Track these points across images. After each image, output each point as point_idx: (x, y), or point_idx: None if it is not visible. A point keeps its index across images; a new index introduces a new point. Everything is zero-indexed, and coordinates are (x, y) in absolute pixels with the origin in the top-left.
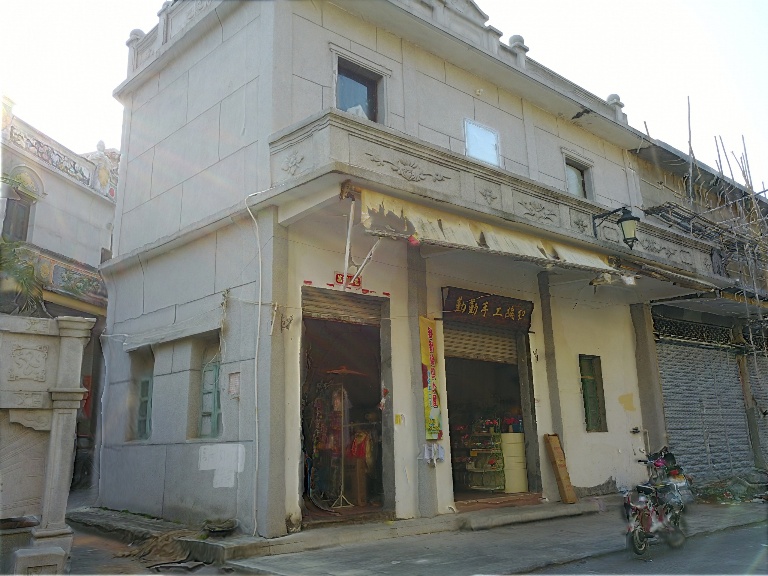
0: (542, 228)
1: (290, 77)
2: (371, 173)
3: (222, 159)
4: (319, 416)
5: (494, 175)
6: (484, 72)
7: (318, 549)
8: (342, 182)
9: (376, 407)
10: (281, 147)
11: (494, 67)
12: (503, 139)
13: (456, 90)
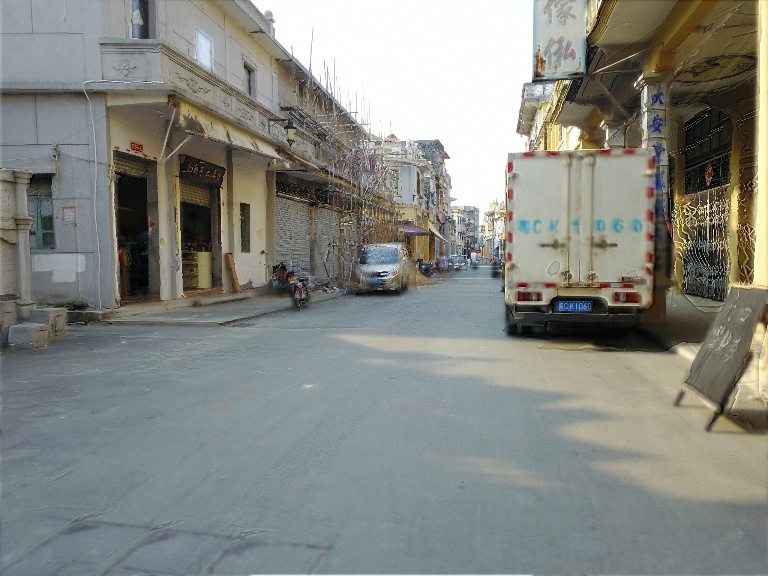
0: (253, 130)
1: None
2: (188, 93)
3: (36, 33)
4: None
5: (230, 89)
6: None
7: (137, 315)
8: (169, 94)
9: (142, 233)
10: (112, 50)
11: None
12: (214, 46)
13: (192, 4)
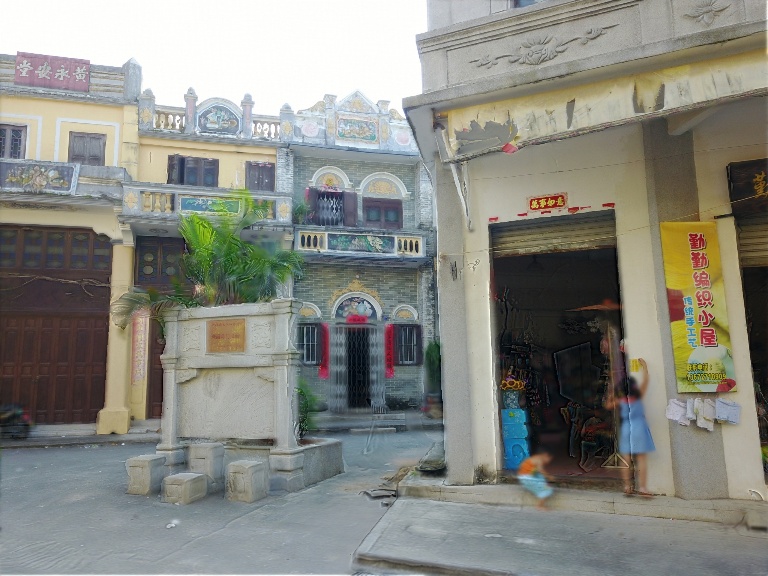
0: None
1: (448, 4)
2: (448, 91)
3: None
4: None
5: None
6: None
7: (493, 505)
8: (433, 113)
9: None
10: None
11: None
12: None
13: None
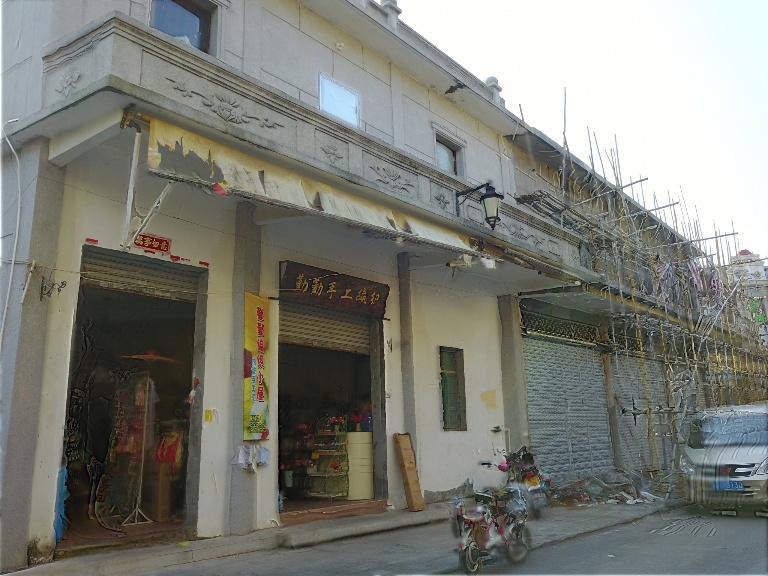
0: (393, 196)
1: None
2: (164, 98)
3: None
4: (120, 412)
5: (341, 131)
6: (345, 23)
7: None
8: (124, 107)
9: (185, 401)
10: (57, 62)
11: (357, 19)
12: (365, 103)
13: (312, 39)
